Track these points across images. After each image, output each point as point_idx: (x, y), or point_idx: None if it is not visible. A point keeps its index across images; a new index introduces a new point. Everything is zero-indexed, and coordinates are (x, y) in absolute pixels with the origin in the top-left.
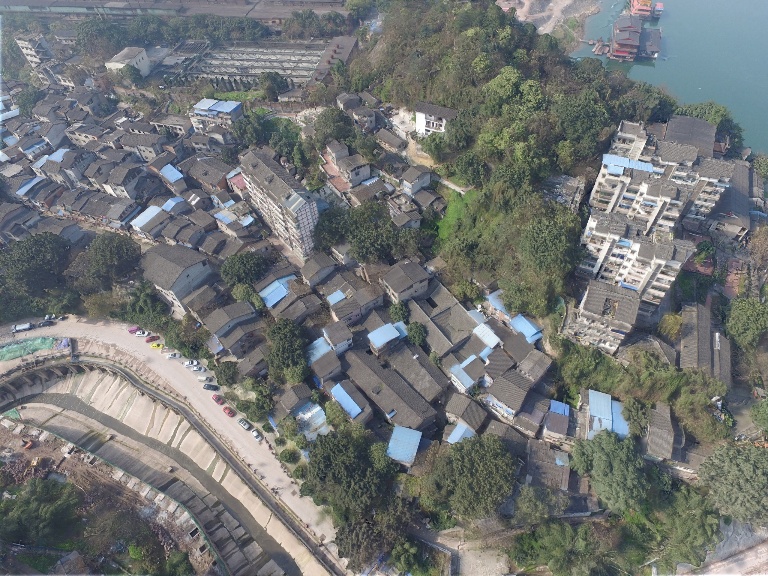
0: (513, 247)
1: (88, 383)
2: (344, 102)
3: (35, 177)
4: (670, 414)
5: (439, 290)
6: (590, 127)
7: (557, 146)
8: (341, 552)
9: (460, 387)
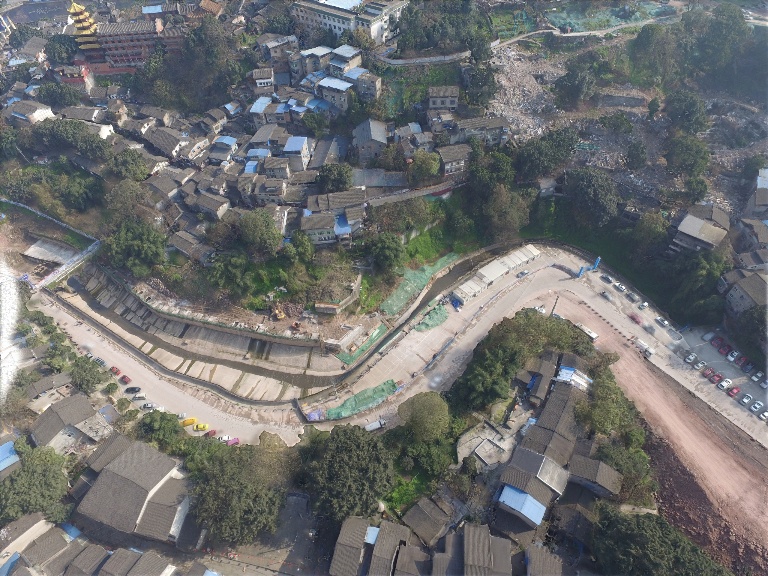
0: None
1: None
2: None
3: None
4: None
5: None
6: None
7: None
8: (23, 283)
9: None
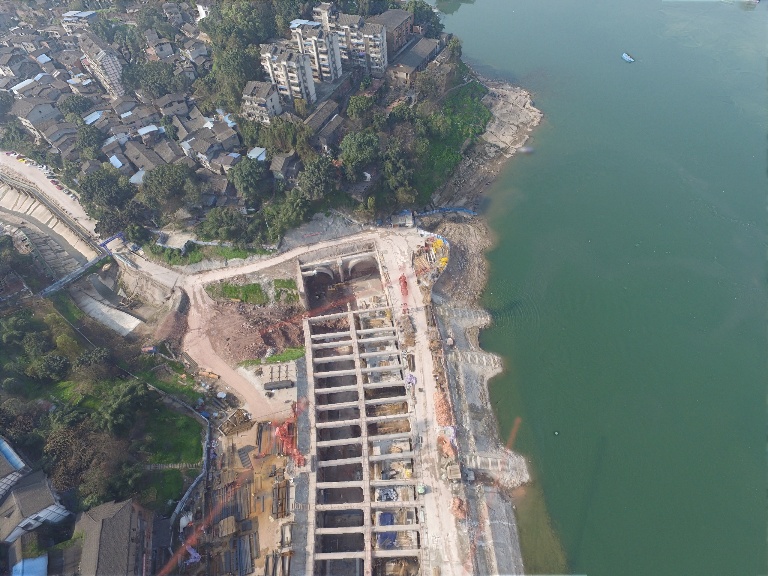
0: None
1: None
2: (165, 8)
3: None
4: (294, 154)
5: (194, 110)
6: (293, 4)
7: (275, 19)
8: None
9: None
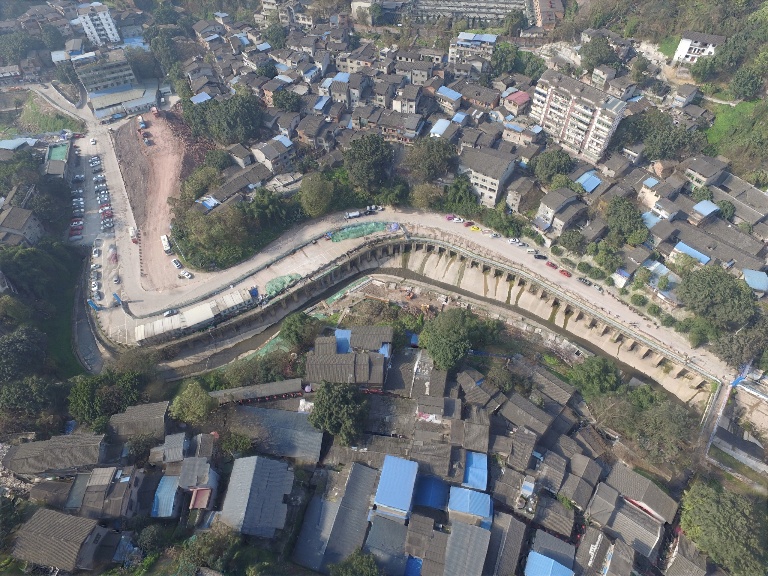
0: None
1: (416, 260)
2: (593, 36)
3: (322, 96)
4: None
5: (730, 179)
6: None
7: None
8: (727, 353)
9: None
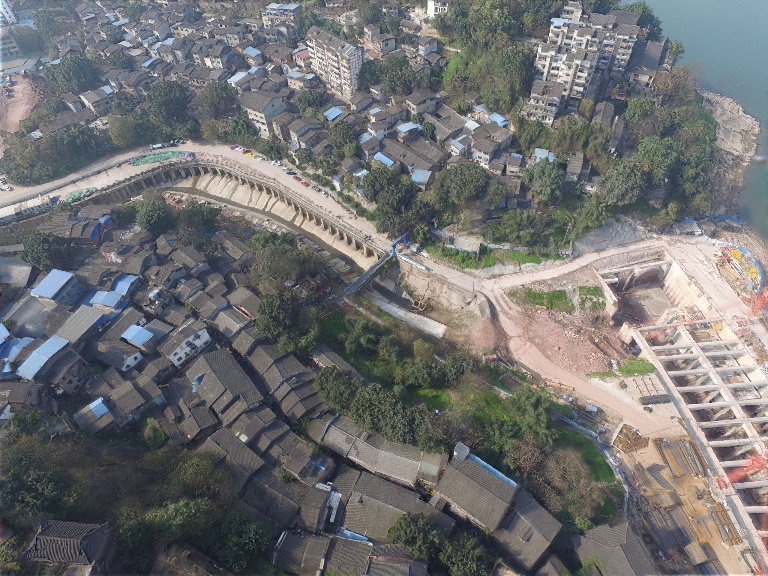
0: (491, 72)
1: (203, 181)
2: (375, 3)
3: (152, 57)
4: (583, 156)
5: (443, 108)
6: (545, 2)
7: (523, 17)
8: (384, 228)
9: (456, 154)
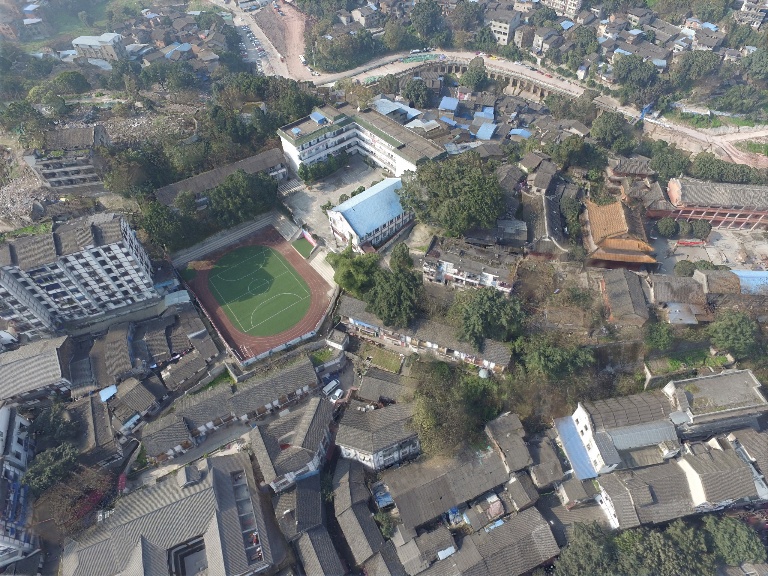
0: None
1: None
2: None
3: None
4: None
5: (657, 21)
6: None
7: None
8: (637, 97)
9: None
